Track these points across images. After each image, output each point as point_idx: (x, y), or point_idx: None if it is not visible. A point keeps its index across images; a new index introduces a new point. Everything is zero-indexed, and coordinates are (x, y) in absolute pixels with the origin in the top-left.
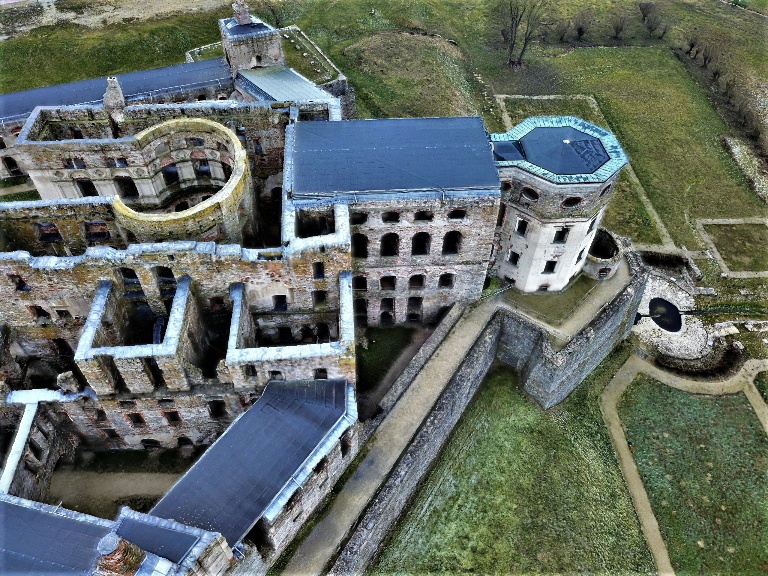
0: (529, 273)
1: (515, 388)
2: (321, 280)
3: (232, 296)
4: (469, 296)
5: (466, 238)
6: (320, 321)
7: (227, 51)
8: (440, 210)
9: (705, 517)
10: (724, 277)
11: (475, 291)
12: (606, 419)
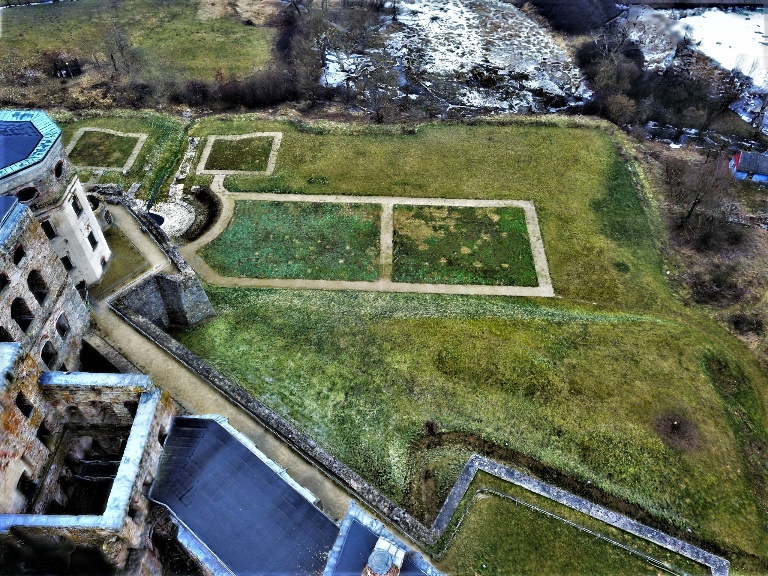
0: (88, 260)
1: (187, 332)
2: (33, 412)
3: (3, 527)
4: (84, 322)
5: (41, 270)
6: (64, 457)
7: None
8: (6, 264)
9: (324, 253)
10: (127, 173)
11: (83, 312)
12: (231, 286)
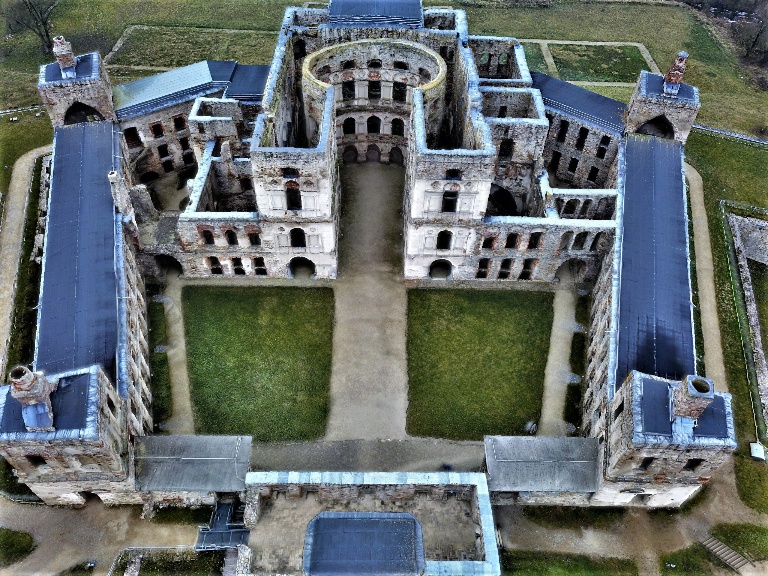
0: None
1: None
2: None
3: None
4: None
5: None
6: None
7: (90, 100)
8: None
9: None
10: None
11: None
12: None
